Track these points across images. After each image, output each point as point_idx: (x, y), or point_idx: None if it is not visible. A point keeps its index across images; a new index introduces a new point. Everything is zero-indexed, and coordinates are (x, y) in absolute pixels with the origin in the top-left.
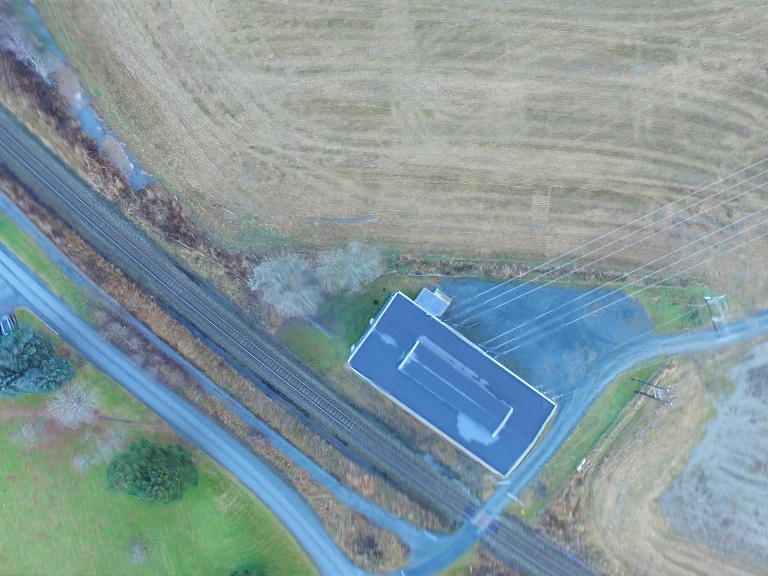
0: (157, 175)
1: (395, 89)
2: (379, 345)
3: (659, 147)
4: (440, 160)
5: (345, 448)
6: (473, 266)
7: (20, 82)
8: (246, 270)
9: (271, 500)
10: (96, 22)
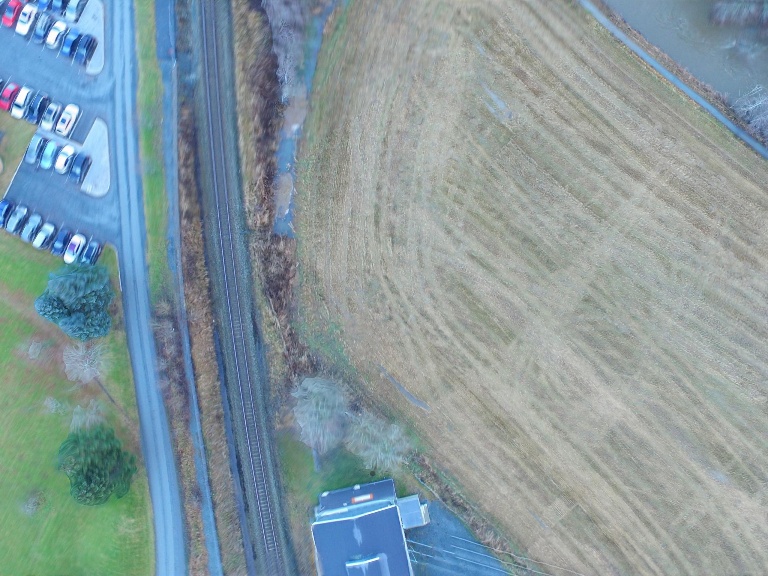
0: (299, 235)
1: (528, 329)
2: (347, 532)
3: (683, 547)
4: (514, 411)
5: (252, 559)
6: (468, 510)
7: (263, 82)
8: (300, 364)
9: (163, 553)
10: (357, 87)
